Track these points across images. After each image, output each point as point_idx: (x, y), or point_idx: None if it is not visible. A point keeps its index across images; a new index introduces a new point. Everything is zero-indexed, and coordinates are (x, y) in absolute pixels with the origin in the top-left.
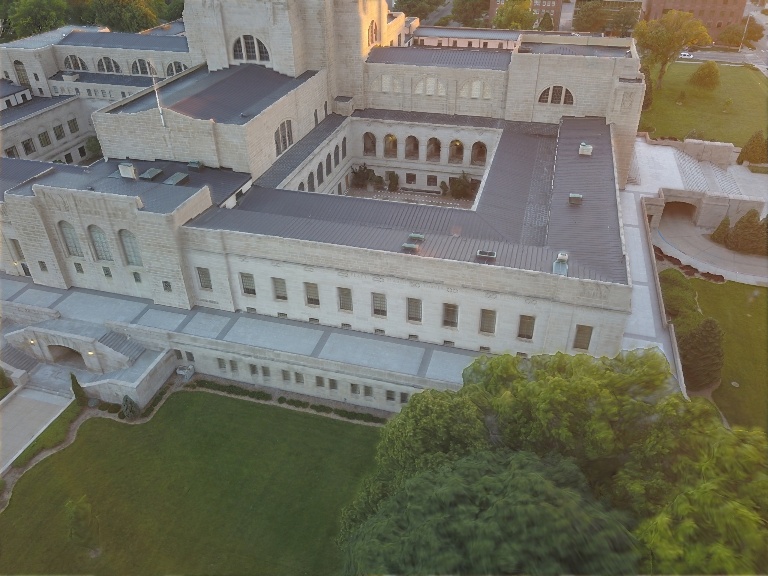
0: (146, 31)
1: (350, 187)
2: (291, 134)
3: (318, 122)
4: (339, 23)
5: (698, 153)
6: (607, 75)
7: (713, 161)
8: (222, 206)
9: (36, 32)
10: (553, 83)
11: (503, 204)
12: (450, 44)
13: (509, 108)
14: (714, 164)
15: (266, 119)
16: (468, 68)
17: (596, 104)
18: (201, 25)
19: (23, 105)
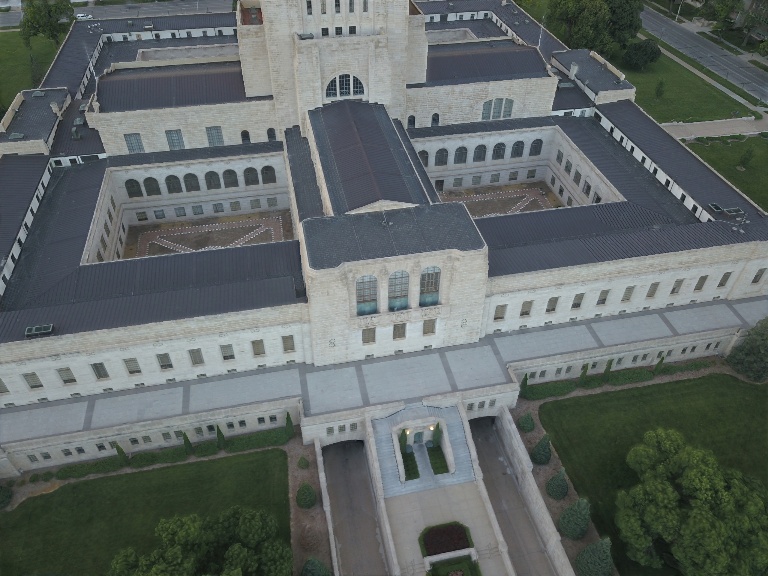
0: (95, 331)
1: None
2: None
3: None
4: None
5: None
6: None
7: None
8: None
9: None
10: None
11: None
12: None
13: None
14: None
15: None
16: None
17: None
18: None
19: None
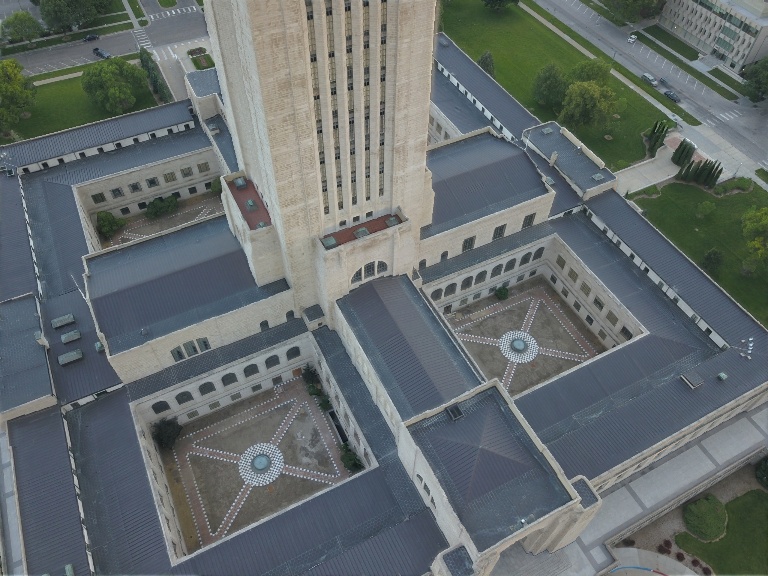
0: None
1: None
2: (209, 343)
3: (270, 327)
4: None
5: None
6: (455, 531)
7: None
8: (72, 403)
9: None
10: (424, 479)
11: (207, 575)
12: (614, 240)
13: None
14: None
15: (153, 346)
16: (385, 389)
17: None
18: None
19: (184, 132)
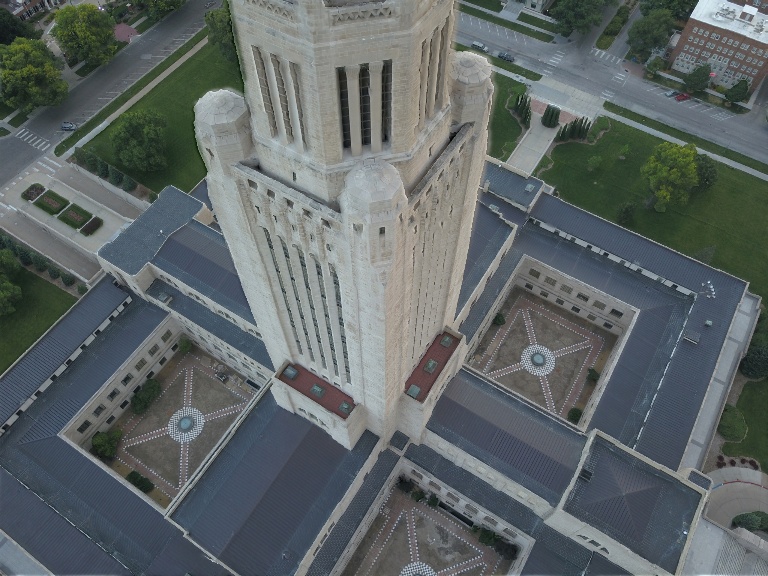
0: None
1: (395, 485)
2: None
3: (368, 473)
4: (403, 410)
5: (749, 547)
6: (645, 568)
7: (762, 557)
8: None
9: (151, 4)
10: (593, 539)
11: None
12: (568, 238)
13: (549, 522)
14: (762, 559)
15: None
16: (518, 484)
17: (629, 568)
18: (271, 389)
19: (124, 311)
